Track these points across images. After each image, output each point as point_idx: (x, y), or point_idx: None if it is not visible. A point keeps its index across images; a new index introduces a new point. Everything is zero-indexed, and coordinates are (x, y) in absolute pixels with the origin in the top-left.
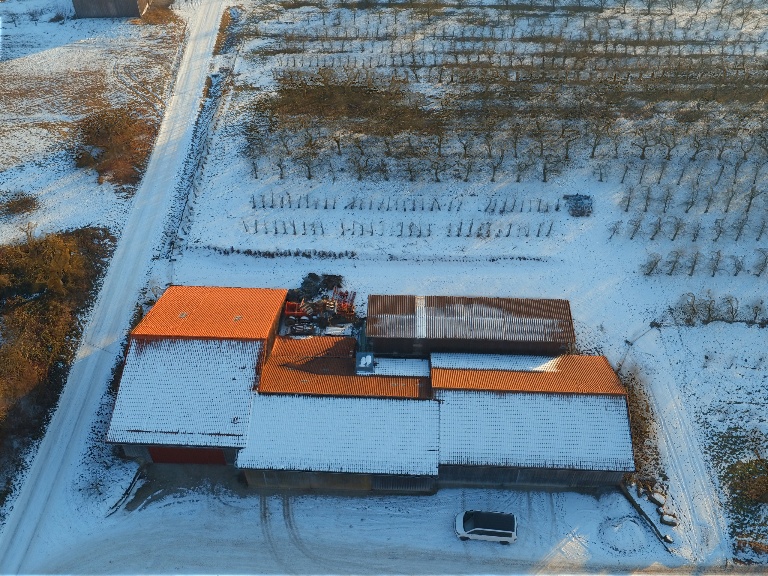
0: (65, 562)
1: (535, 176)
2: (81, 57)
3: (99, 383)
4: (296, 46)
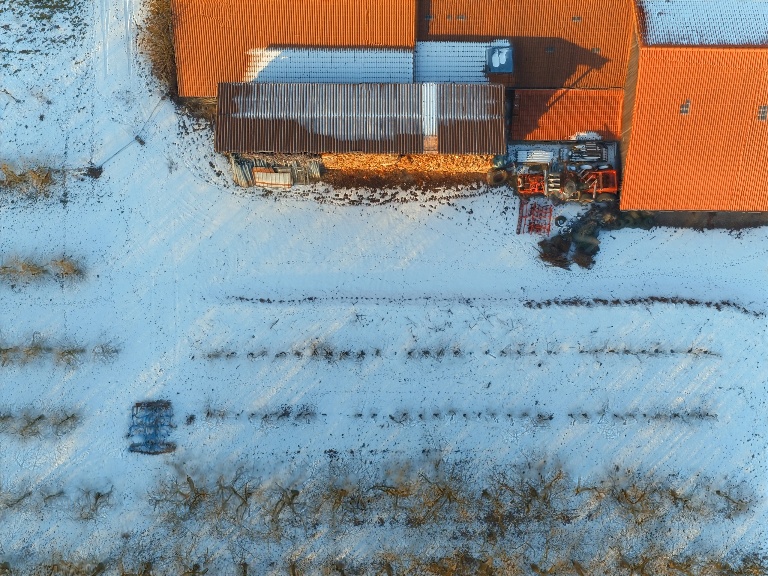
0: None
1: None
2: None
3: None
4: None
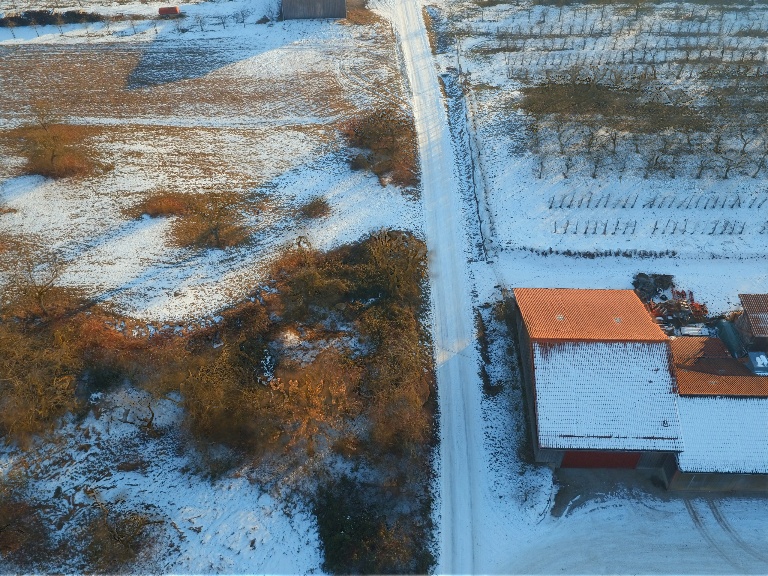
0: (517, 570)
1: None
2: (303, 59)
3: (471, 388)
4: (512, 44)
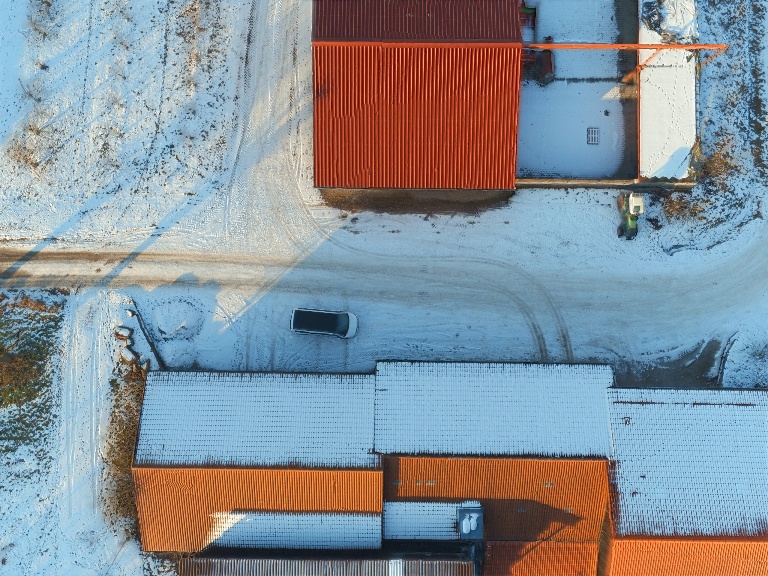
0: (763, 282)
1: None
2: None
3: None
4: None
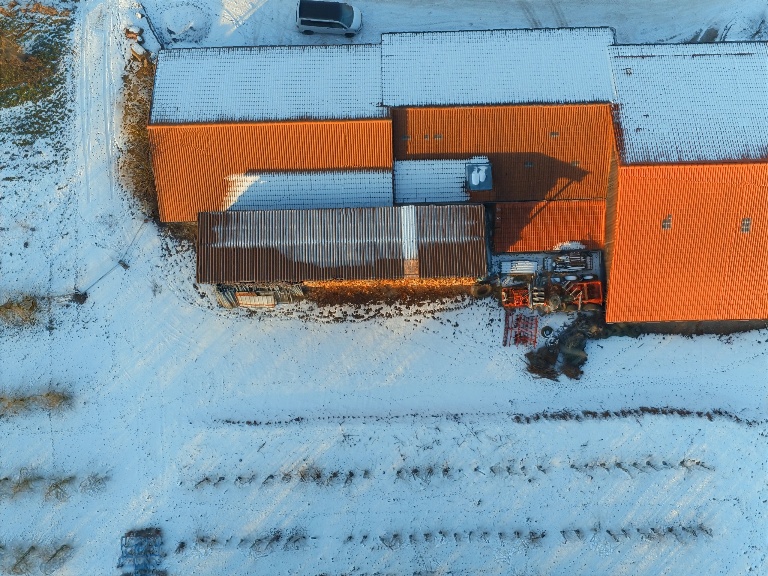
0: None
1: None
2: None
3: None
4: None
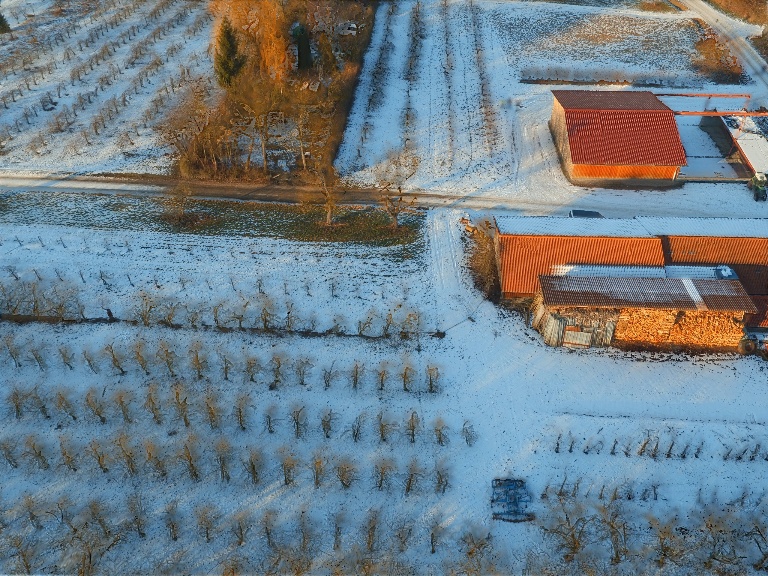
0: None
1: (585, 571)
2: None
3: None
4: None
